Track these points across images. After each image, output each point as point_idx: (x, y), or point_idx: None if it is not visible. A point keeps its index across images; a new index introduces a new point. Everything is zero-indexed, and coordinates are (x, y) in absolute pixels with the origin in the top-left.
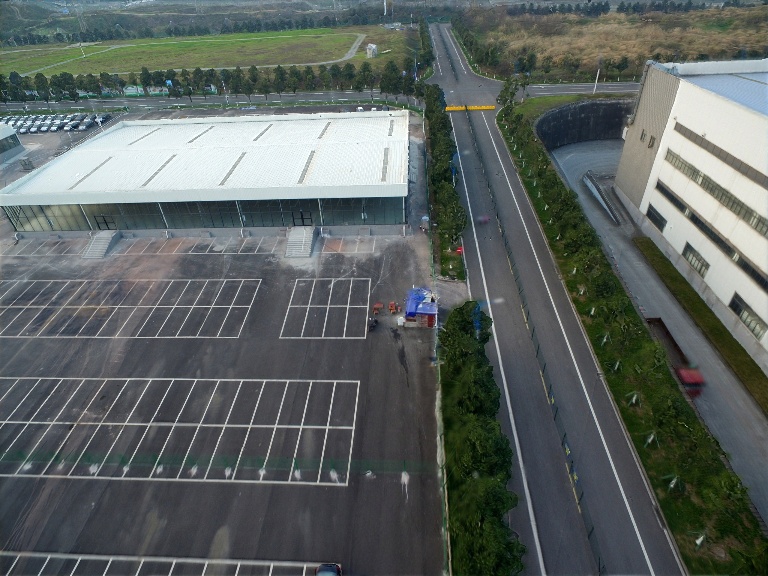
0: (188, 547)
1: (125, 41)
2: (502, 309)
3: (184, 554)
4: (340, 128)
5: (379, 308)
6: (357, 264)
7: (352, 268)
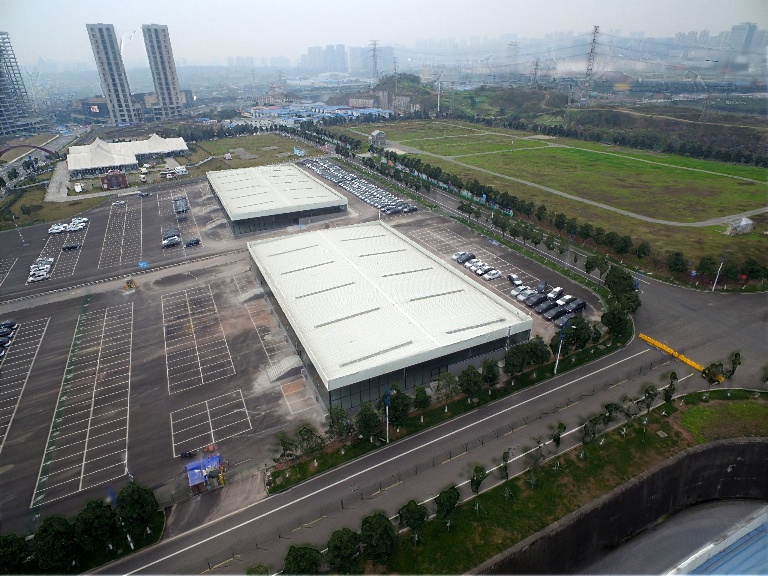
0: (4, 458)
1: (571, 141)
2: (230, 540)
3: (0, 459)
4: (448, 301)
5: (209, 449)
6: (270, 412)
7: (264, 411)
